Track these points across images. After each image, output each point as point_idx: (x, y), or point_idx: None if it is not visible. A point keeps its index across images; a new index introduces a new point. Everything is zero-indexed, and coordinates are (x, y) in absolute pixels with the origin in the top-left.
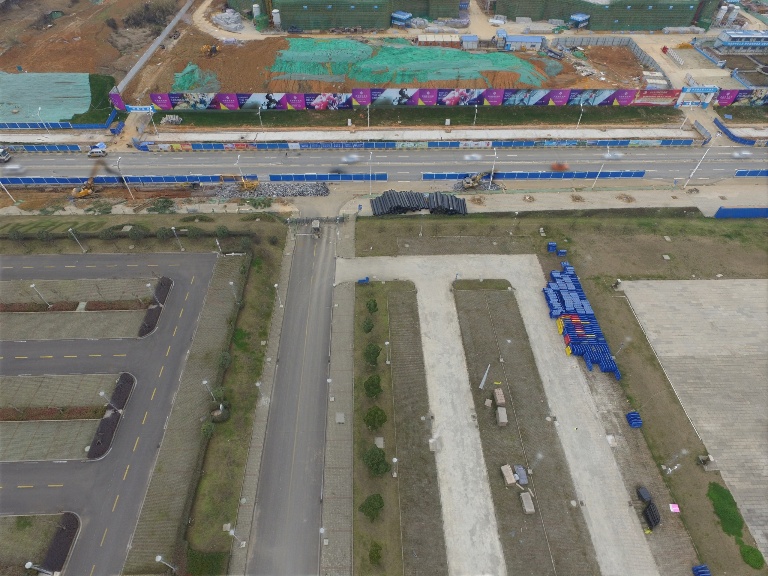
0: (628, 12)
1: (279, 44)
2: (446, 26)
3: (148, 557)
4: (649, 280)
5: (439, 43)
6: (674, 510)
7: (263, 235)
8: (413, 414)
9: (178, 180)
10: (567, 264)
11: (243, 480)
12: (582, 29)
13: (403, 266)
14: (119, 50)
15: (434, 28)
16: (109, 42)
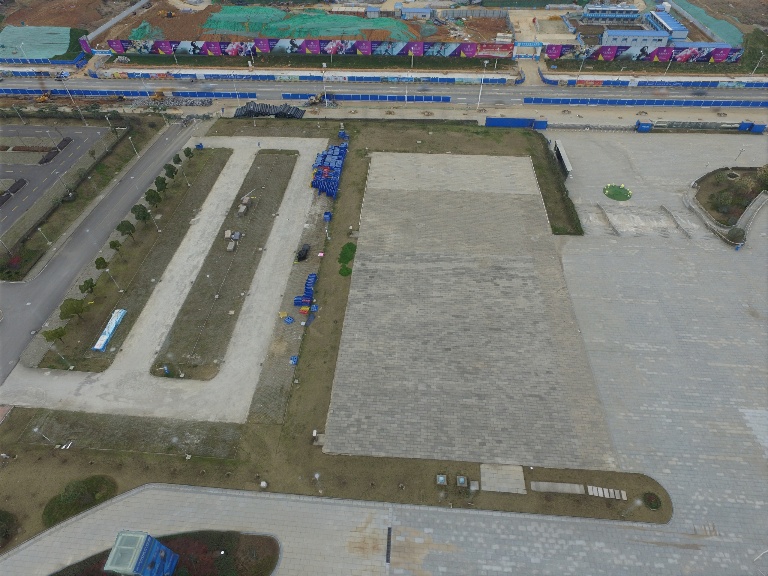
0: None
1: (212, 8)
2: (364, 2)
3: (0, 250)
4: (394, 152)
5: (348, 13)
6: (320, 255)
7: (146, 121)
8: (189, 208)
9: (109, 94)
10: None
11: (69, 226)
12: (477, 6)
13: (232, 141)
14: (102, 15)
15: (351, 3)
16: (96, 10)
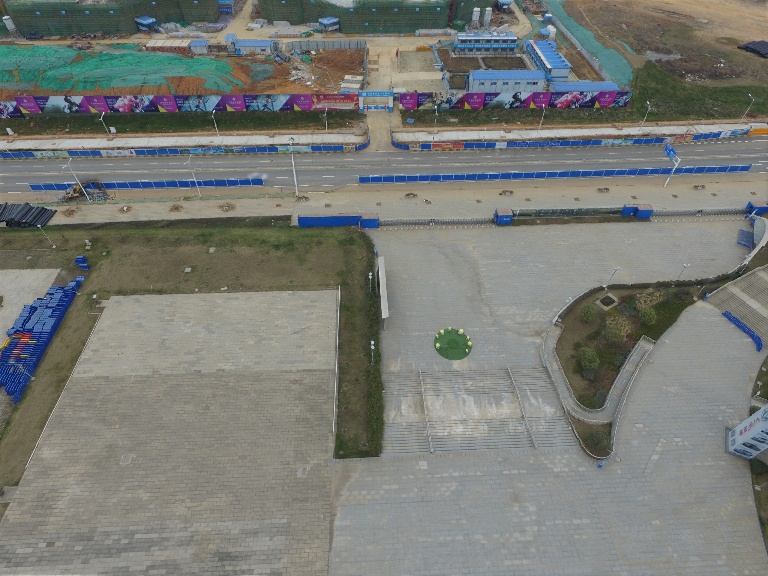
0: (375, 15)
1: None
2: (197, 31)
3: None
4: (143, 295)
5: (167, 48)
6: None
7: None
8: None
9: None
10: (82, 279)
11: None
12: (334, 32)
13: None
14: None
15: (178, 33)
16: None
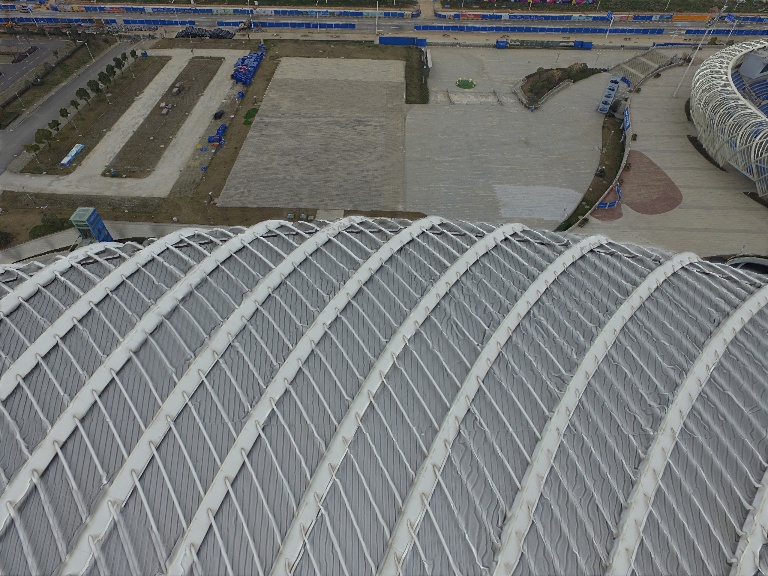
0: None
1: None
2: None
3: None
4: (300, 57)
5: None
6: (231, 117)
7: (100, 37)
8: (134, 91)
9: (69, 21)
10: (263, 53)
11: (38, 100)
12: None
13: (172, 52)
14: None
15: None
16: None
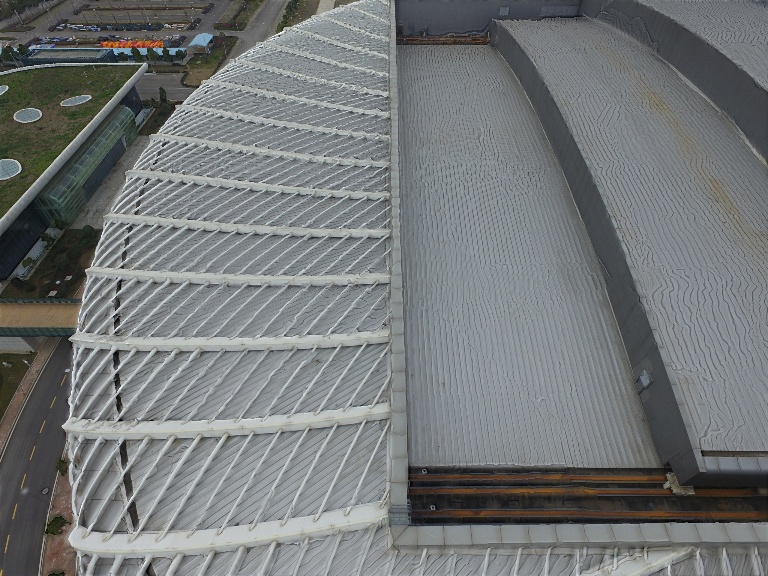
0: None
1: None
2: None
3: None
4: None
5: None
6: None
7: None
8: (310, 12)
9: None
10: None
11: (251, 17)
12: None
13: None
14: None
15: None
16: None
